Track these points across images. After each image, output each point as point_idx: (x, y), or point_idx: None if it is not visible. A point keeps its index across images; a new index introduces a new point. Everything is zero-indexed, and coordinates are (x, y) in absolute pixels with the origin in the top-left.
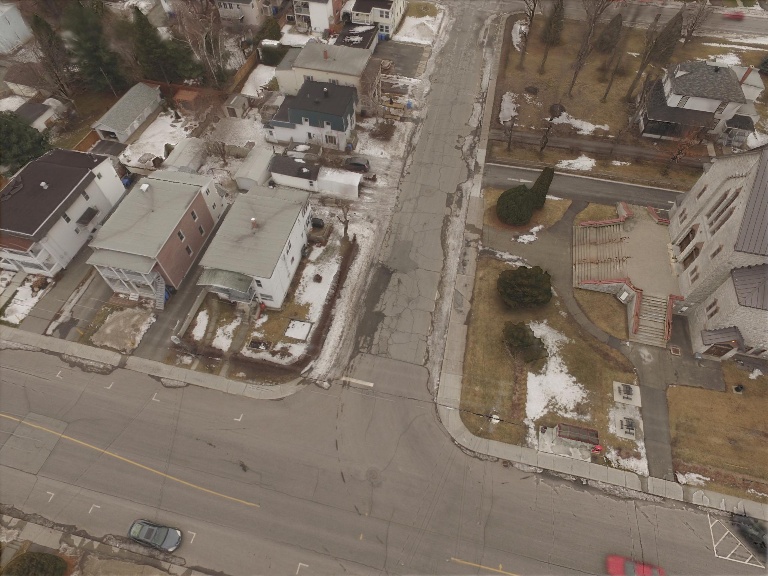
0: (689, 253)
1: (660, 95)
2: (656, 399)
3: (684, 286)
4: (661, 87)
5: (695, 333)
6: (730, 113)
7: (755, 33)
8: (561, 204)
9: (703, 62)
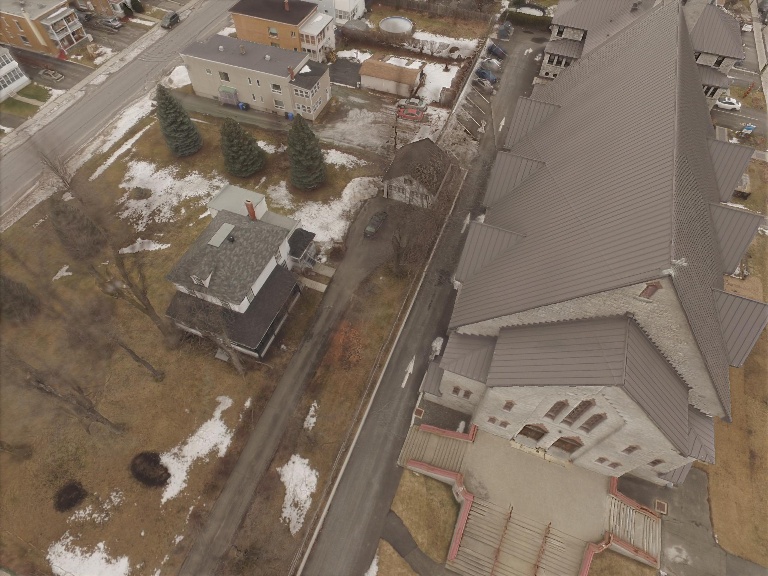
0: (555, 441)
1: (213, 310)
2: (743, 573)
3: (601, 470)
4: (196, 300)
5: (643, 475)
6: (285, 248)
7: (104, 121)
8: (391, 567)
9: (207, 247)
